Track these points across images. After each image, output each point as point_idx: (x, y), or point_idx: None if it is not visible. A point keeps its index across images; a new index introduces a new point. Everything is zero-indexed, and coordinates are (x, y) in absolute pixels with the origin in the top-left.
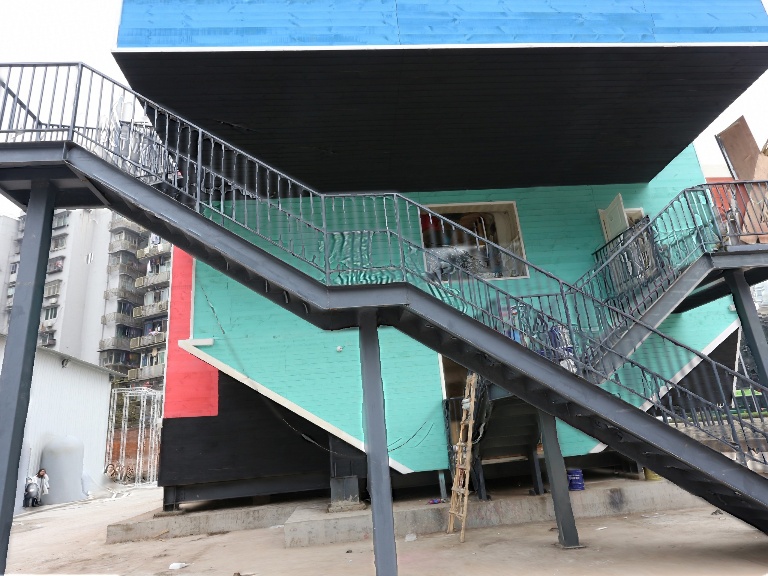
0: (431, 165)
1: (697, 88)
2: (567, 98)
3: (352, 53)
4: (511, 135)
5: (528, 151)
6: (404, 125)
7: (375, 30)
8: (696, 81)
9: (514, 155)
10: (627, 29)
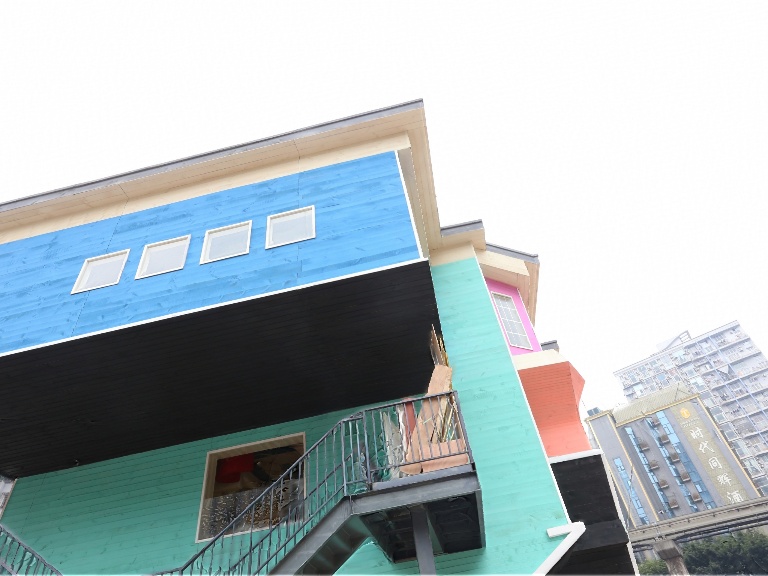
0: (197, 414)
1: (380, 308)
2: (259, 342)
3: (28, 353)
4: (243, 378)
5: (278, 387)
6: (132, 390)
7: (57, 329)
8: (370, 304)
9: (268, 392)
10: (274, 279)
